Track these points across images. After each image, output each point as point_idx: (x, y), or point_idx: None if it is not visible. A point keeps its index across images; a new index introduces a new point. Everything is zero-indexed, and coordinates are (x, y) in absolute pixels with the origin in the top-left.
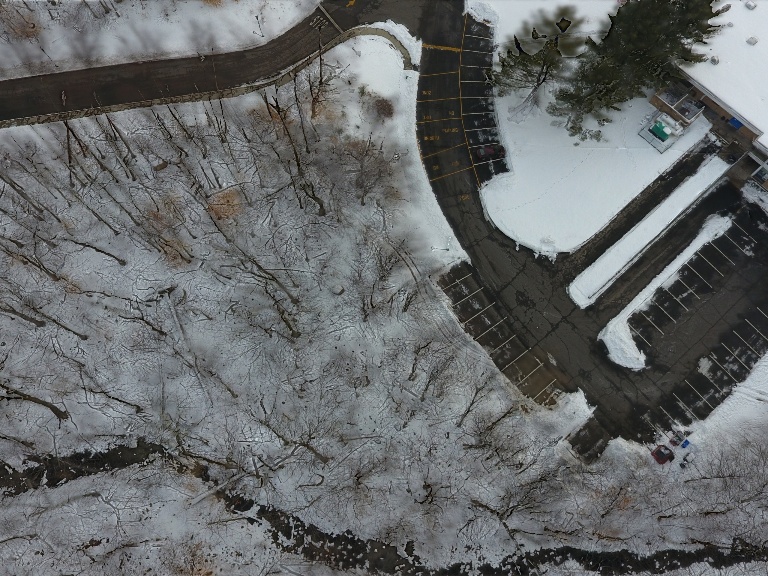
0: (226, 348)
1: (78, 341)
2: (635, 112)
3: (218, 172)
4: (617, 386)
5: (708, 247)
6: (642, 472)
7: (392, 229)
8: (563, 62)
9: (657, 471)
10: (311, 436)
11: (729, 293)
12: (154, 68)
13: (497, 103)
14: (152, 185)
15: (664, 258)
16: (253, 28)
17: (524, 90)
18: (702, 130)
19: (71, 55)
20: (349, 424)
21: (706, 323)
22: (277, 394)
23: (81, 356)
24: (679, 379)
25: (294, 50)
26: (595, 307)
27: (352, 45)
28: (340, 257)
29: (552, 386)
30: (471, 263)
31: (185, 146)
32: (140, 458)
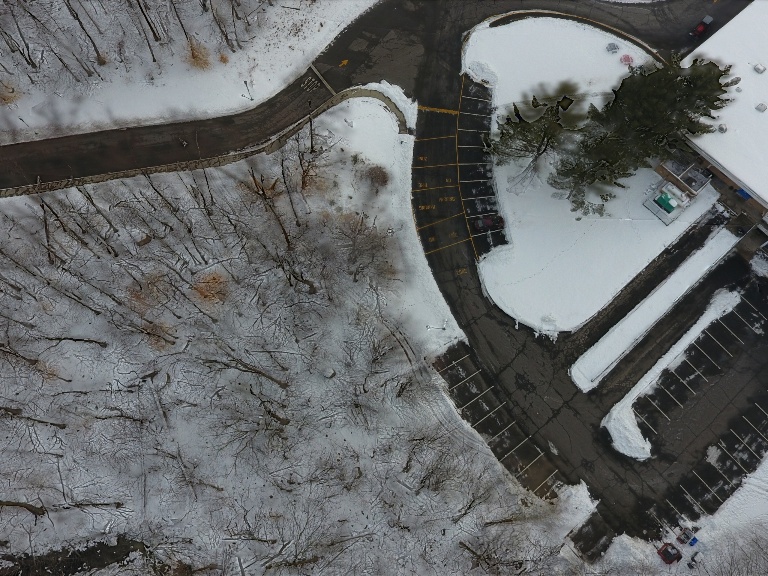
0: (211, 437)
1: (56, 430)
2: (639, 180)
3: (204, 250)
4: (621, 477)
5: (716, 325)
6: (648, 573)
7: (386, 307)
8: (564, 135)
9: (664, 572)
10: (297, 556)
11: (738, 375)
12: (138, 135)
13: (496, 170)
14: (135, 261)
15: (670, 337)
16: (242, 91)
17: (524, 159)
18: (709, 200)
19: (52, 121)
20: (340, 522)
21: (714, 408)
22: (264, 487)
23: (59, 447)
24: (686, 470)
25: (284, 114)
26: (598, 391)
27: (345, 108)
28: (331, 338)
29: (553, 478)
30: (468, 343)
31: (170, 220)
32: (120, 557)
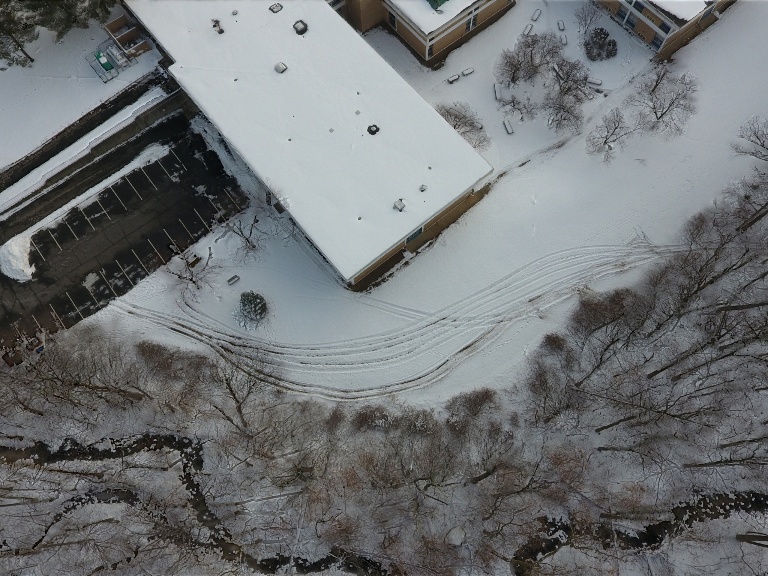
0: None
1: None
2: (95, 44)
3: None
4: None
5: (137, 172)
6: None
7: None
8: None
9: (2, 373)
10: None
11: (141, 215)
12: None
13: None
14: None
15: (91, 181)
16: None
17: None
18: (152, 62)
19: None
20: None
21: (108, 241)
22: None
23: None
24: (61, 291)
25: None
26: (5, 223)
27: None
28: None
29: None
30: None
31: None
32: None
